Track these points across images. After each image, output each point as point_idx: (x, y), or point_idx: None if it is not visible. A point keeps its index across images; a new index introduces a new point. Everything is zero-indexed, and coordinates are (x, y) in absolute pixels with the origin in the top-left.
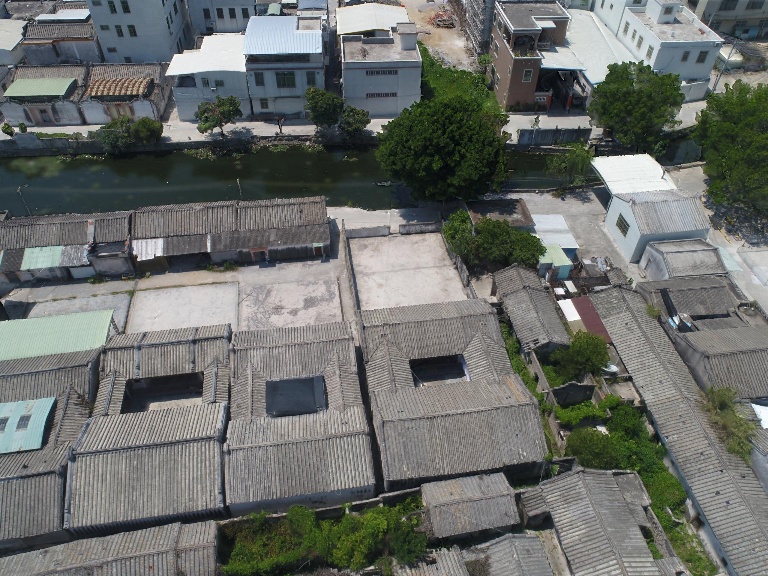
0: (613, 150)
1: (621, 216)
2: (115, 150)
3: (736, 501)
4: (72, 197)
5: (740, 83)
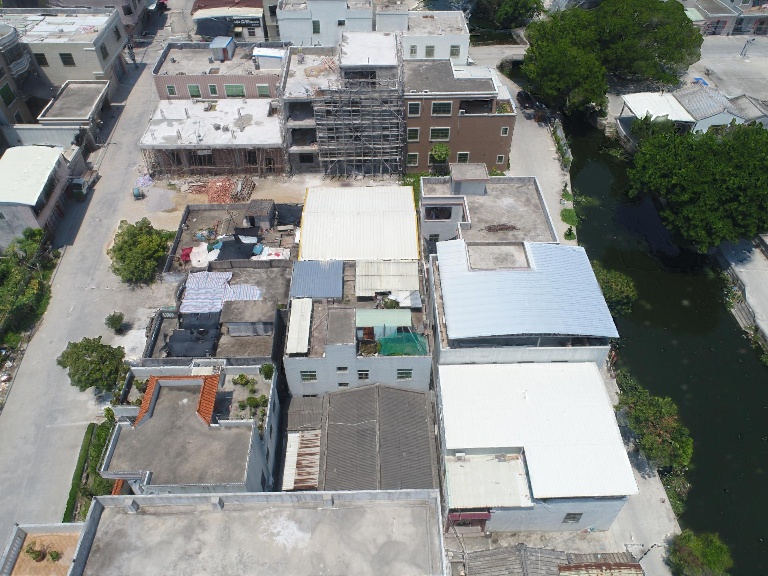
0: (562, 123)
1: (713, 126)
2: None
3: None
4: None
5: (544, 24)
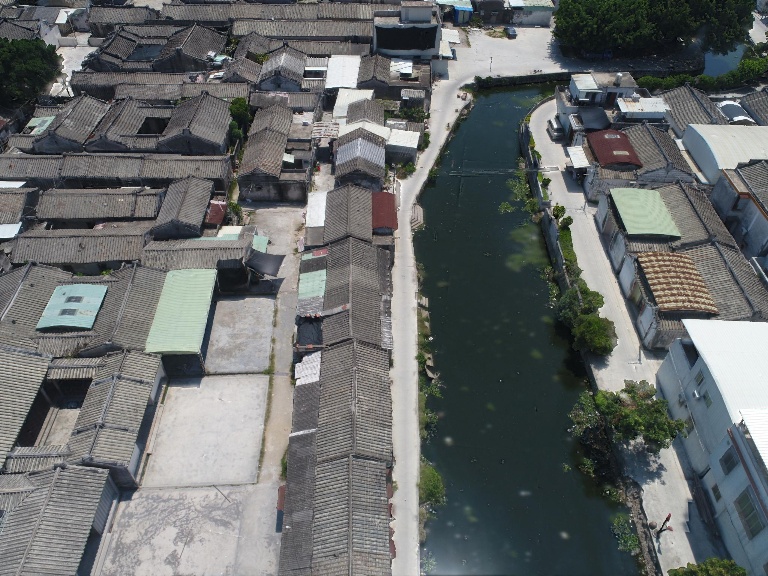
0: None
1: None
2: (559, 312)
3: None
4: (466, 294)
5: None
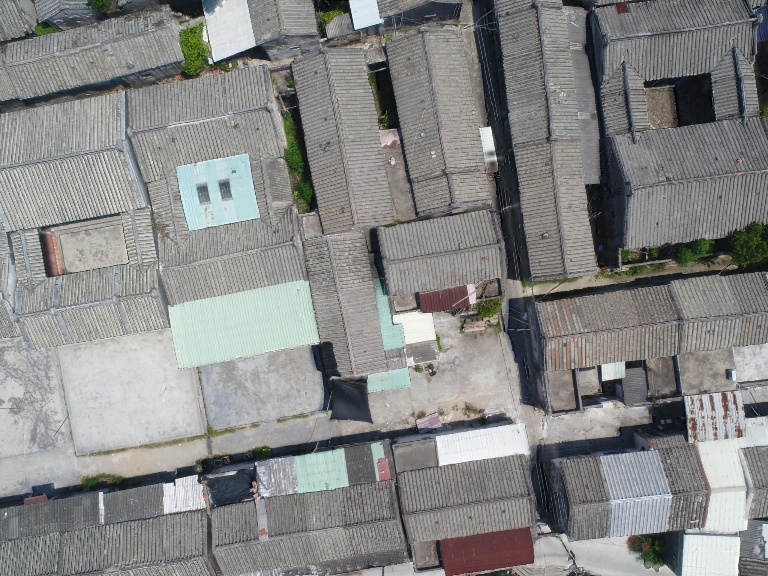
0: None
1: None
2: None
3: None
4: None
5: None
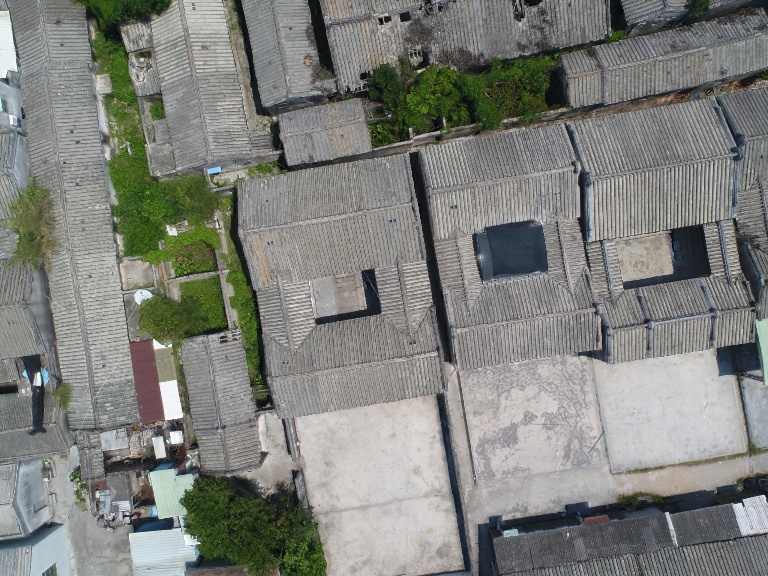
0: None
1: None
2: None
3: (63, 132)
4: None
5: None
